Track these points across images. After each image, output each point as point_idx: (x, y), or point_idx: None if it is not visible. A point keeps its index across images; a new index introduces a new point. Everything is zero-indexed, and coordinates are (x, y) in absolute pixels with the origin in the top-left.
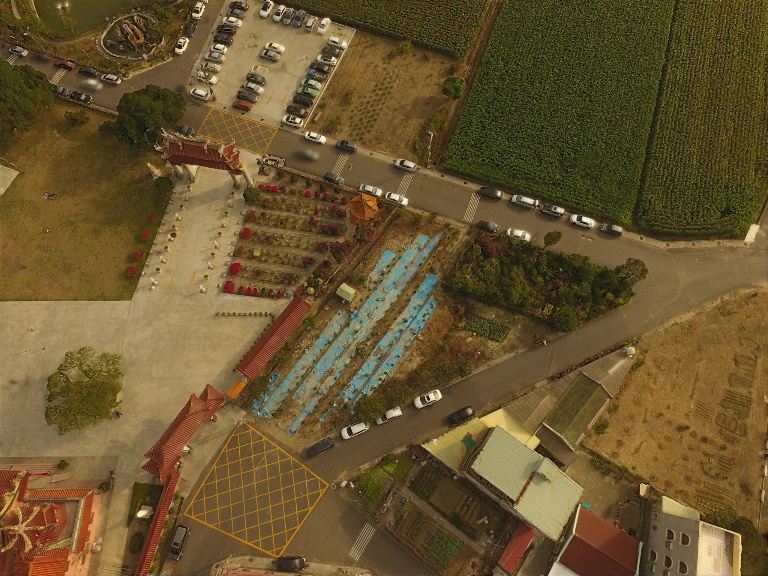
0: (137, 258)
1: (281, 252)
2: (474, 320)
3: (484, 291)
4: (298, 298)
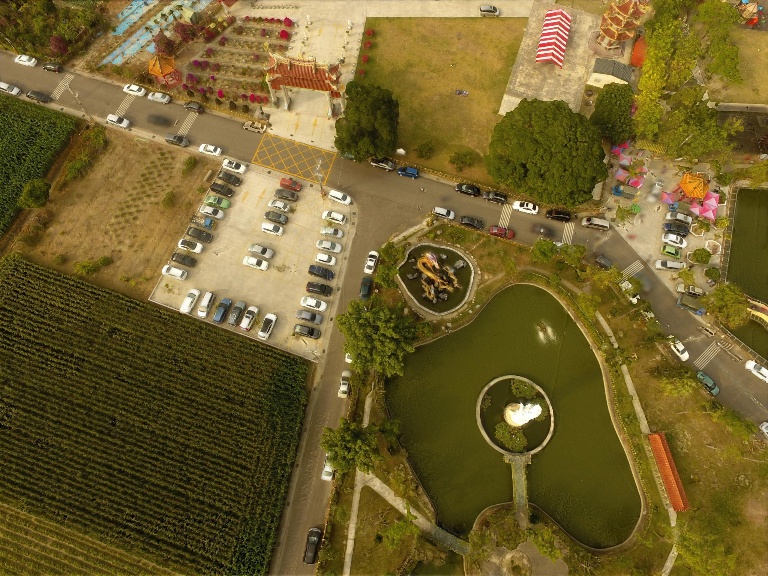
0: (368, 42)
1: (247, 50)
2: (89, 4)
3: (71, 9)
4: (226, 2)
